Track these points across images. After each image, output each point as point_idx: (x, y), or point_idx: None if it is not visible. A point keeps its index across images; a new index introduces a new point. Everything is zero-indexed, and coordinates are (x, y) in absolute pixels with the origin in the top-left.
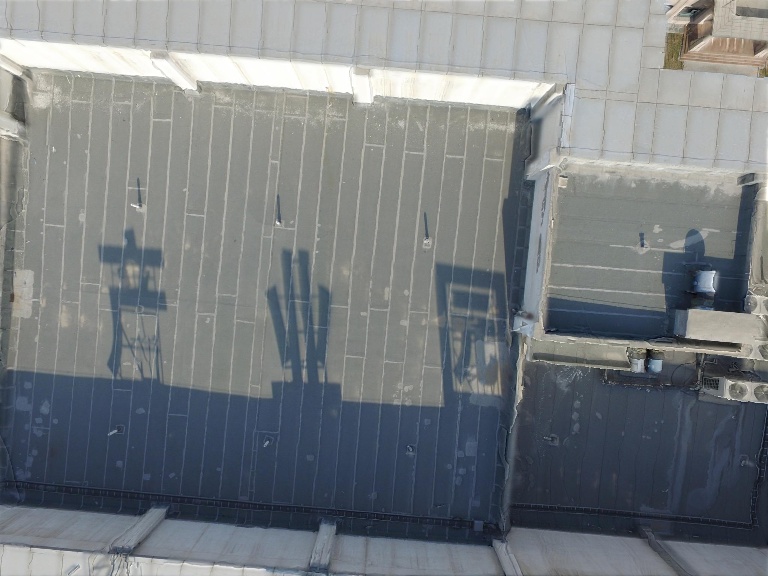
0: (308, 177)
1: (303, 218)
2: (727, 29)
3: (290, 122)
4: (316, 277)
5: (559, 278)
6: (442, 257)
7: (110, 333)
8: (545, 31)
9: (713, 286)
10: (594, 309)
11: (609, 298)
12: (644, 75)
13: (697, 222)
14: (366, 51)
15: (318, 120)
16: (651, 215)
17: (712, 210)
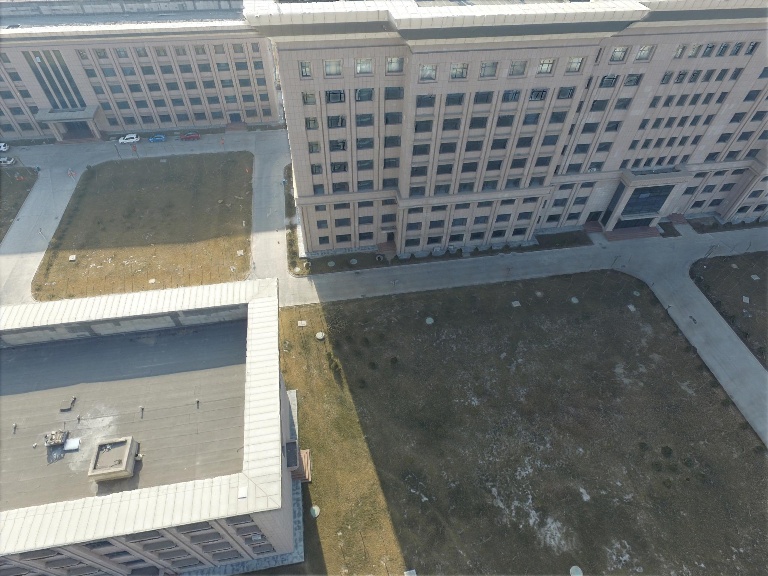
0: None
1: None
2: None
3: None
4: None
5: None
6: None
7: (527, 3)
8: None
9: None
10: None
11: None
12: None
13: None
14: None
15: None
16: None
17: None
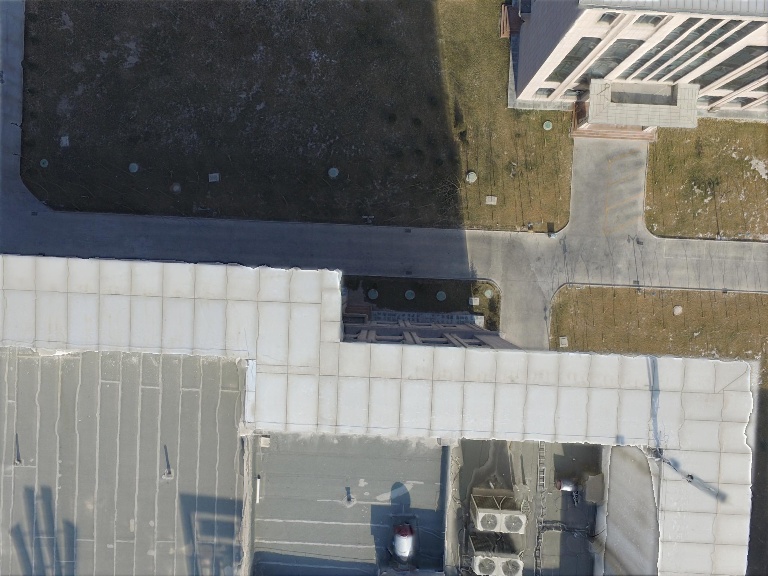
0: (46, 415)
1: (43, 455)
2: (603, 116)
3: (24, 362)
4: (60, 512)
5: (270, 533)
6: (185, 487)
7: None
8: (223, 310)
9: (413, 543)
10: (306, 562)
11: (320, 551)
12: (325, 348)
13: (401, 475)
14: (46, 336)
15: (52, 359)
16: (355, 470)
17: (415, 463)
